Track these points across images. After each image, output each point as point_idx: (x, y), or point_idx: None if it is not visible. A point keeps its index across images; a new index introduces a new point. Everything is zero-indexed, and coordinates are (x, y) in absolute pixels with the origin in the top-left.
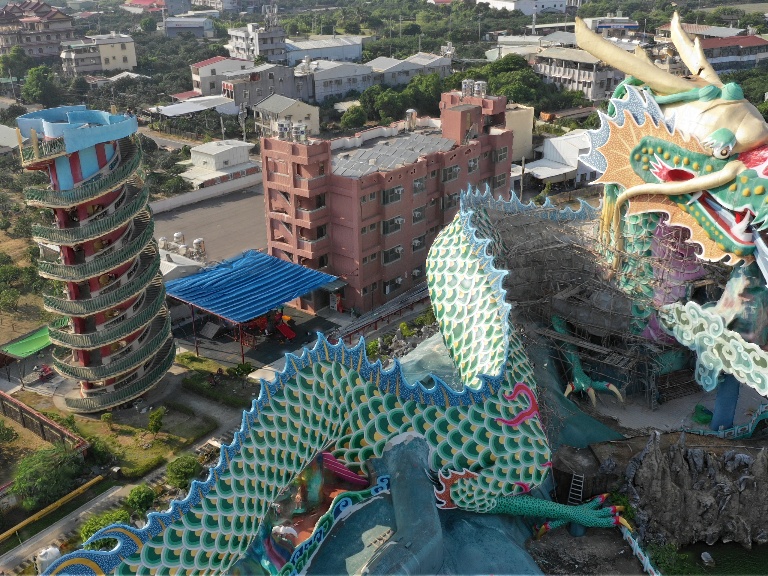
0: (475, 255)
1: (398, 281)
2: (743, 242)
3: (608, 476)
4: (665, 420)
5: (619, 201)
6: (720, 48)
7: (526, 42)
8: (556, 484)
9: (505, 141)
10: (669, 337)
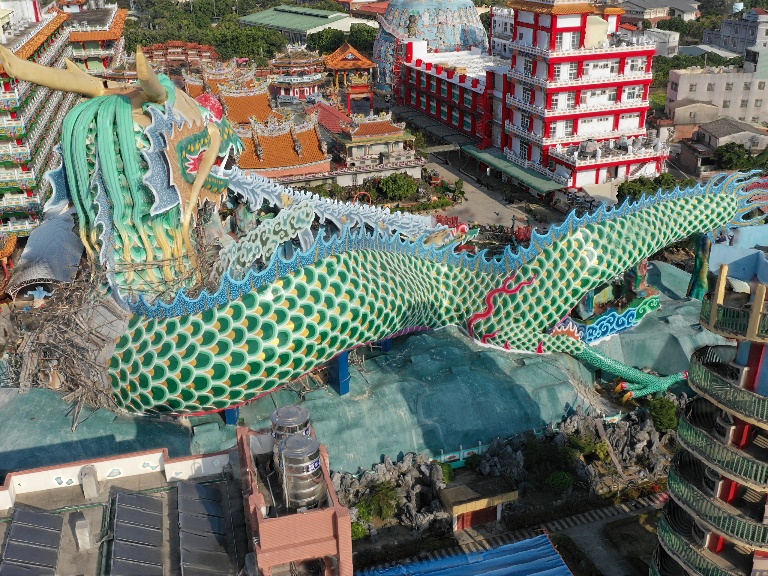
0: None
1: None
2: (226, 176)
3: None
4: None
5: None
6: None
7: None
8: None
9: None
10: None
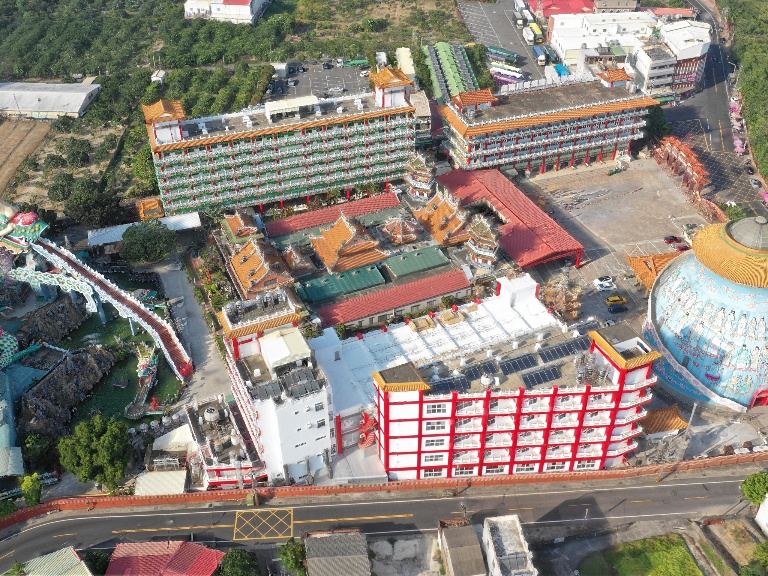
0: None
1: None
2: (27, 245)
3: (31, 334)
4: (30, 307)
5: None
6: None
7: None
8: None
9: None
10: (16, 281)
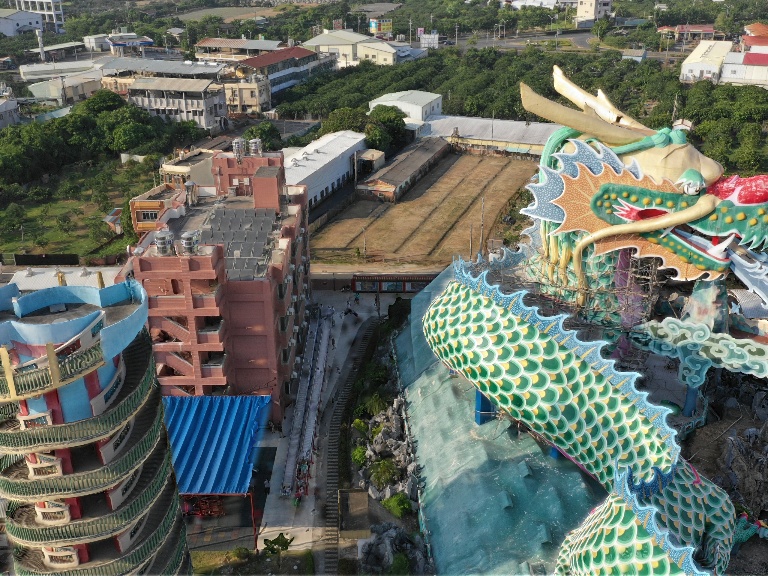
0: (545, 333)
1: (294, 376)
2: (723, 260)
3: None
4: None
5: (583, 245)
6: (282, 62)
7: (57, 70)
8: None
9: (305, 198)
10: (645, 352)
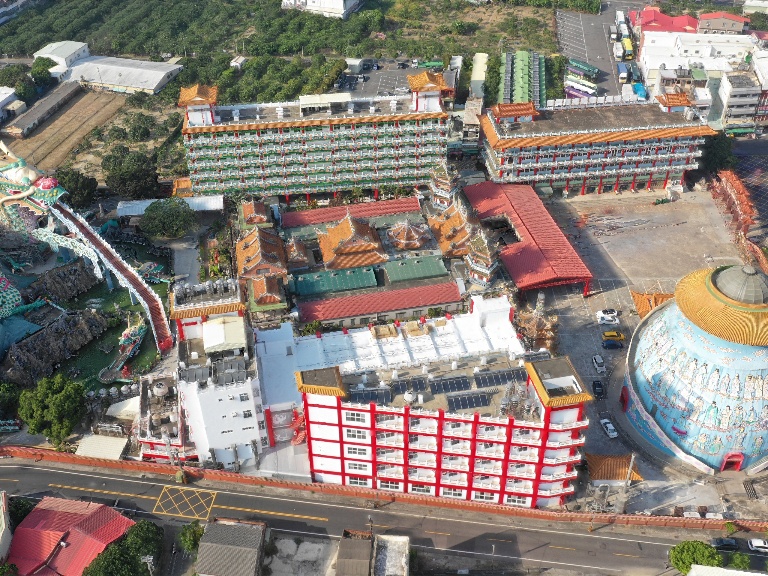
0: None
1: None
2: (46, 208)
3: (39, 291)
4: (49, 266)
5: (1, 203)
6: None
7: None
8: (25, 301)
9: None
10: (38, 240)
